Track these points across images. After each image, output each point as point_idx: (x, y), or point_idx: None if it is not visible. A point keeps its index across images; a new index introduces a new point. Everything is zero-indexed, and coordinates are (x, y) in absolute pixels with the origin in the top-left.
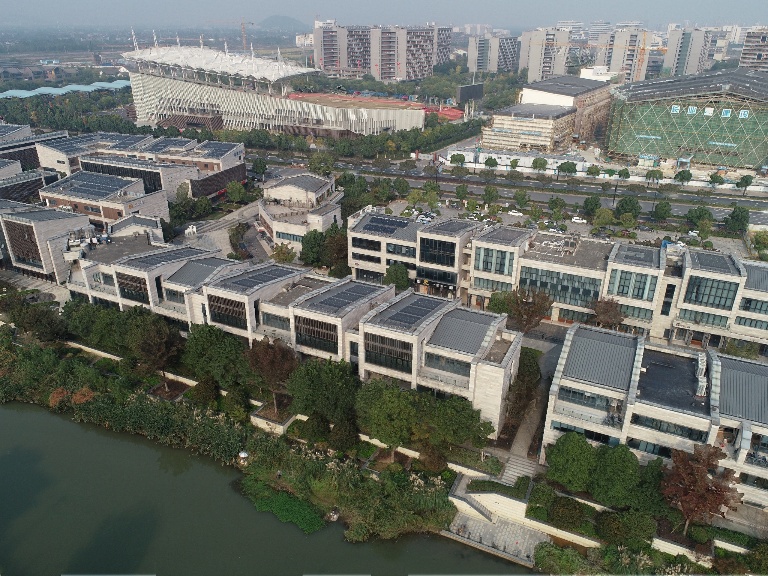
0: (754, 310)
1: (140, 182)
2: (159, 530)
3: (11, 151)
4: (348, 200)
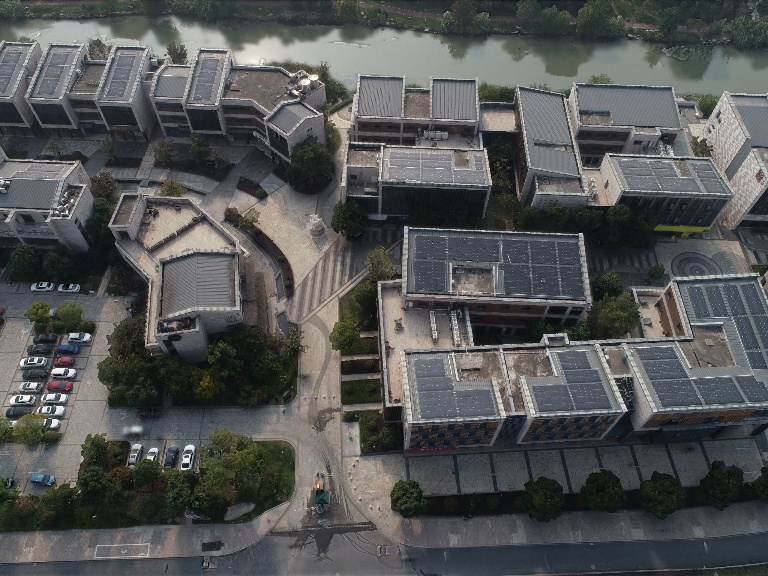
0: None
1: None
2: None
3: None
4: (133, 328)
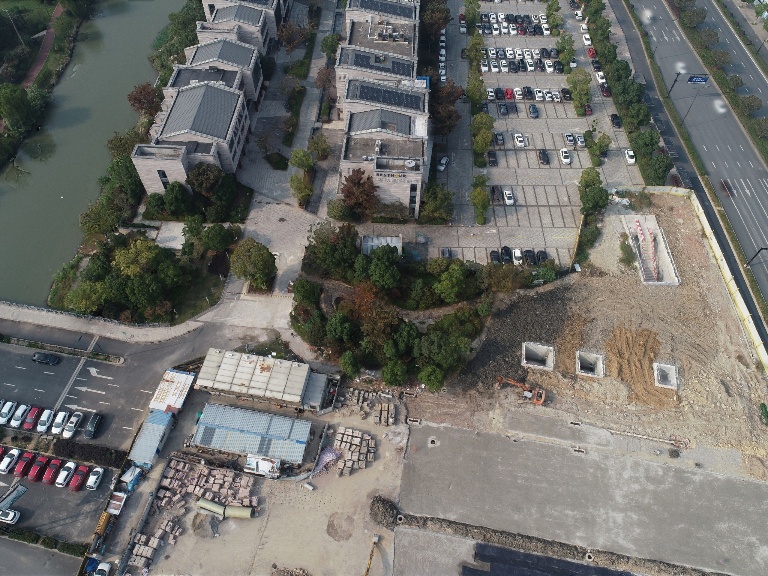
0: None
1: None
2: (143, 16)
3: None
4: None
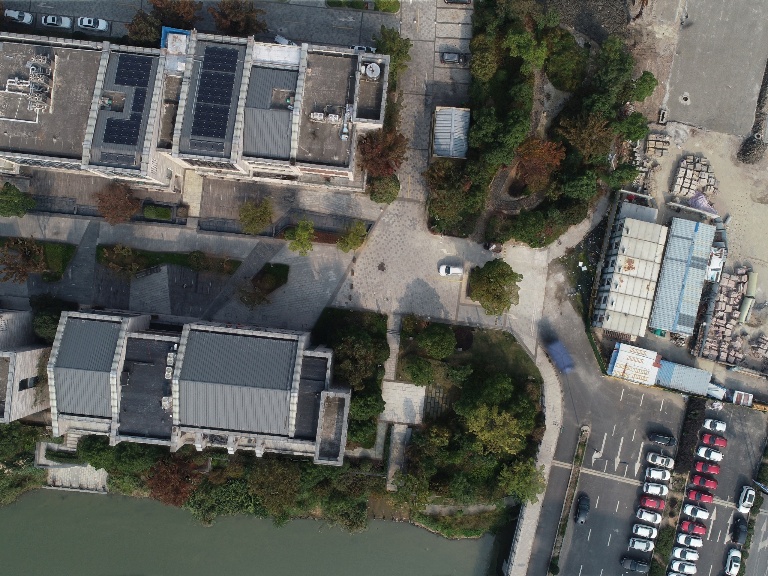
0: (264, 164)
1: None
2: None
3: None
4: None
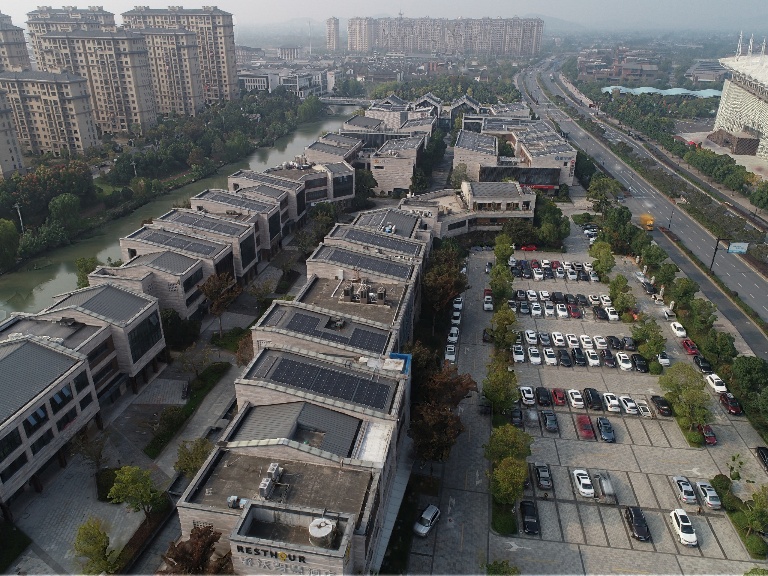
0: None
1: (414, 150)
2: None
3: (478, 122)
4: (518, 220)
